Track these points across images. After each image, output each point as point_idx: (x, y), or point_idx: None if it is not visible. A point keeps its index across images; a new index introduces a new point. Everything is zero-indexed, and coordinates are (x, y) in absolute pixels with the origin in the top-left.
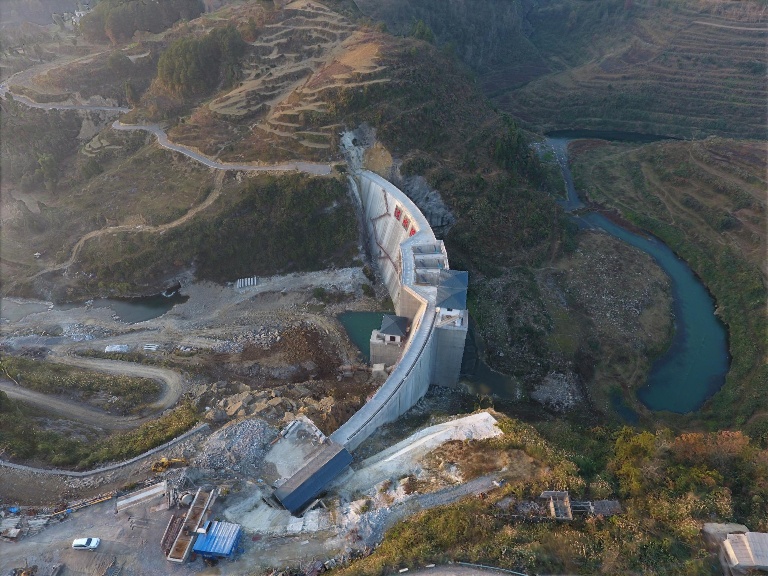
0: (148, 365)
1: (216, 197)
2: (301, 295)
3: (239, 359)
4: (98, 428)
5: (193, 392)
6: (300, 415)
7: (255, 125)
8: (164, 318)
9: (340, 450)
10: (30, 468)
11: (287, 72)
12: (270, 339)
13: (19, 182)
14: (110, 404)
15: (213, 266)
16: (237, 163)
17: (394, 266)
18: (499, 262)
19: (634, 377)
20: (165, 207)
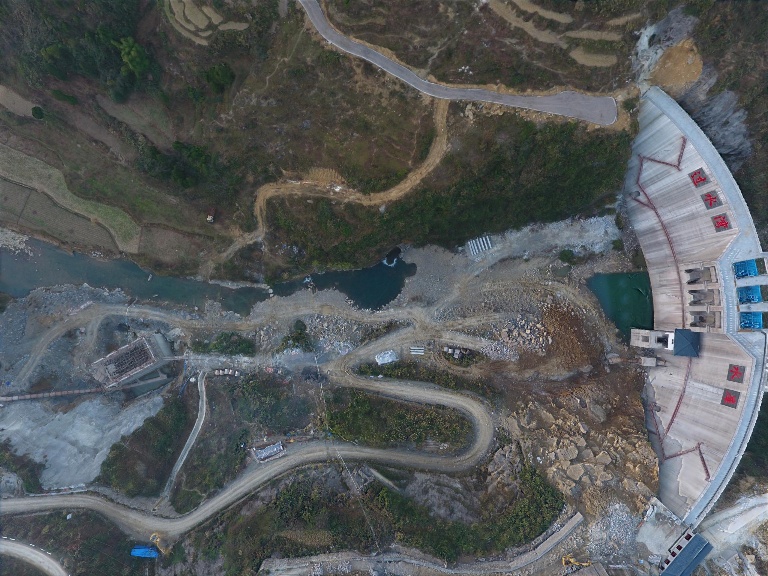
0: (441, 390)
1: (444, 152)
2: (545, 259)
3: (518, 369)
4: (456, 485)
5: (505, 427)
6: (642, 486)
7: (485, 3)
8: (409, 306)
9: (705, 544)
10: (473, 572)
11: None
12: (542, 342)
13: (98, 82)
14: (443, 450)
15: (441, 232)
16: (463, 85)
17: (664, 229)
18: None
19: None
20: (370, 164)
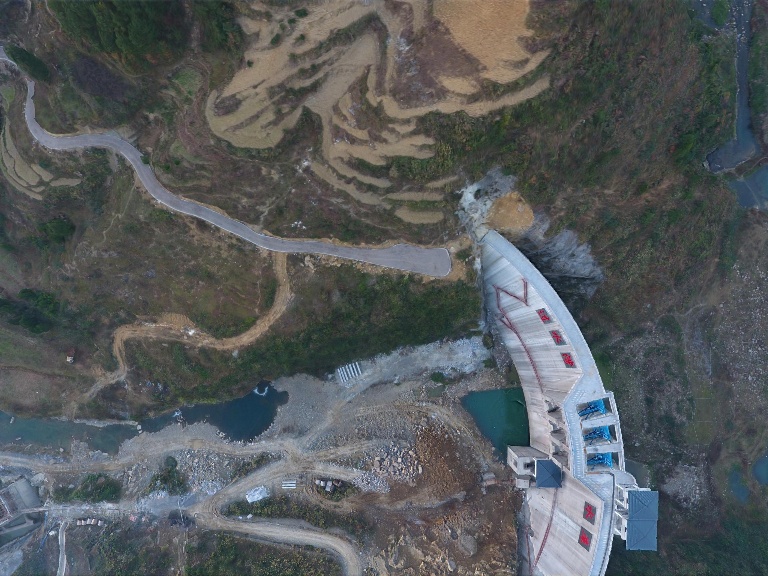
0: (310, 531)
1: (288, 301)
2: (417, 382)
3: (390, 500)
4: None
5: (373, 567)
6: None
7: (306, 166)
8: (280, 438)
9: None
10: None
11: (333, 28)
12: (412, 472)
13: None
14: None
15: (306, 364)
16: (298, 239)
17: (527, 353)
18: (645, 319)
19: (756, 451)
20: (218, 311)
